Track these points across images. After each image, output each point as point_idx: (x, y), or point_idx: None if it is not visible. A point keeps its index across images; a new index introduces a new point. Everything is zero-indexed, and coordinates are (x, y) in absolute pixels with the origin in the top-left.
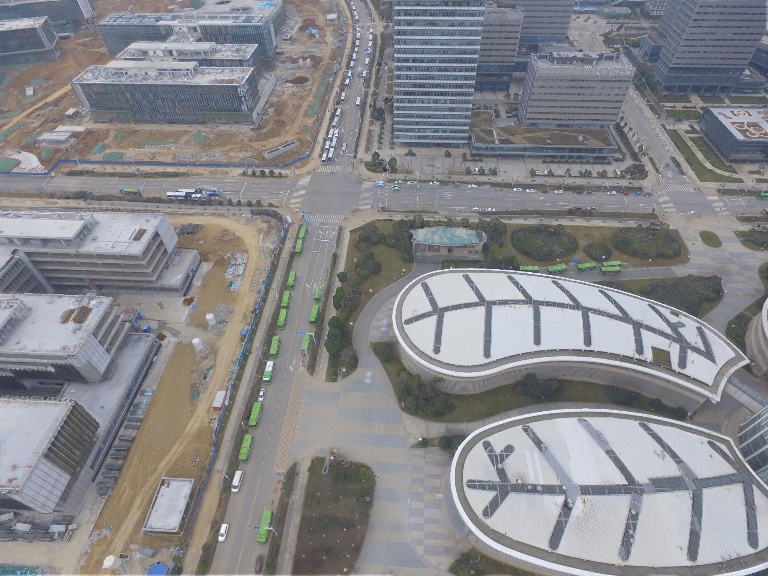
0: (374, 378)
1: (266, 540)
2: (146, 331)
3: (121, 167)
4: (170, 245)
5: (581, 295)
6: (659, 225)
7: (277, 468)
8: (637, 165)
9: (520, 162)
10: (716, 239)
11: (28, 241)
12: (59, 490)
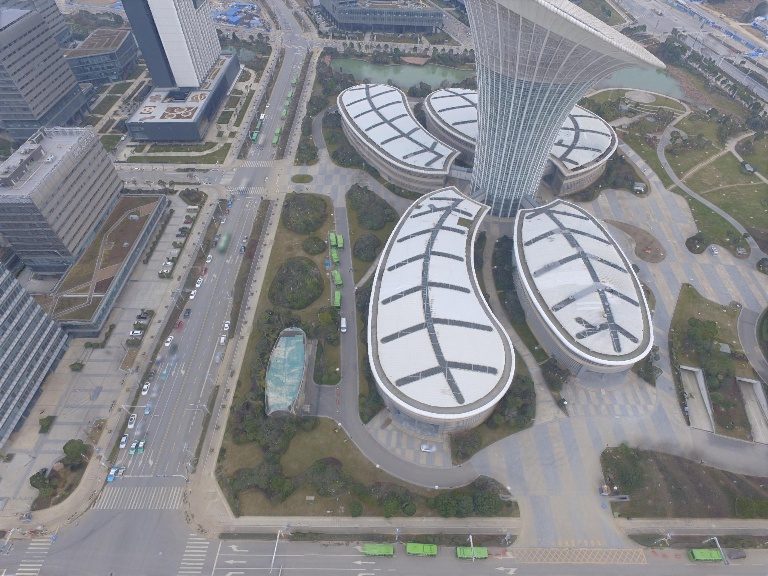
0: (502, 457)
1: None
2: None
3: None
4: None
5: (410, 253)
6: (292, 197)
7: (642, 559)
8: (186, 193)
9: (135, 285)
10: (303, 176)
11: None
12: None
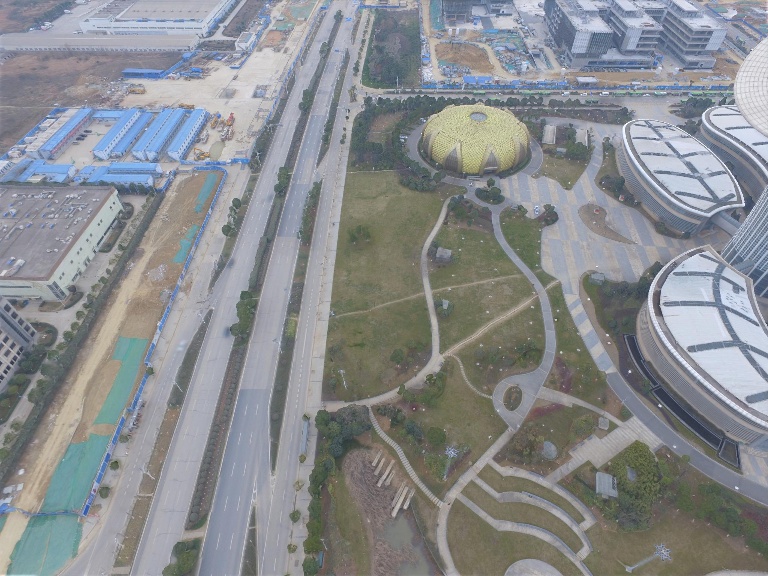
0: (683, 123)
1: (587, 101)
2: (654, 63)
3: (759, 35)
4: (710, 46)
5: None
6: None
7: (616, 103)
8: None
9: None
10: None
11: (674, 6)
12: (580, 50)
